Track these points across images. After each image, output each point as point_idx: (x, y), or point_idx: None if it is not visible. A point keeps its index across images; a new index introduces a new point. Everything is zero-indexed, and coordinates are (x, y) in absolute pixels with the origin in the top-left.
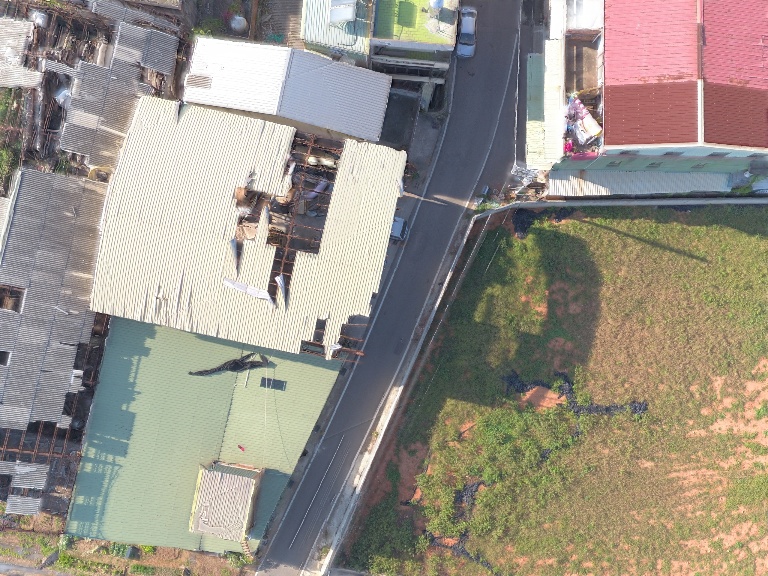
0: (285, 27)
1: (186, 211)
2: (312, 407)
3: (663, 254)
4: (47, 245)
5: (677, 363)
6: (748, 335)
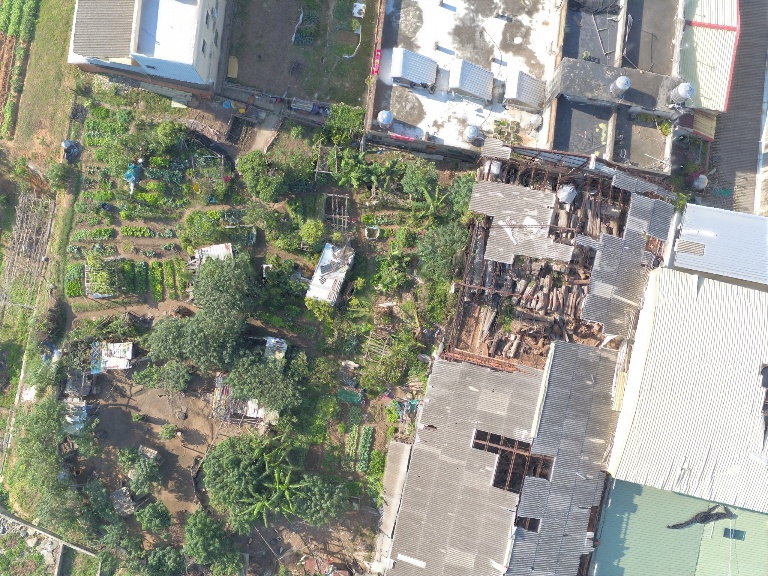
0: (730, 181)
1: (715, 386)
2: (766, 555)
3: None
4: (572, 414)
5: None
6: None
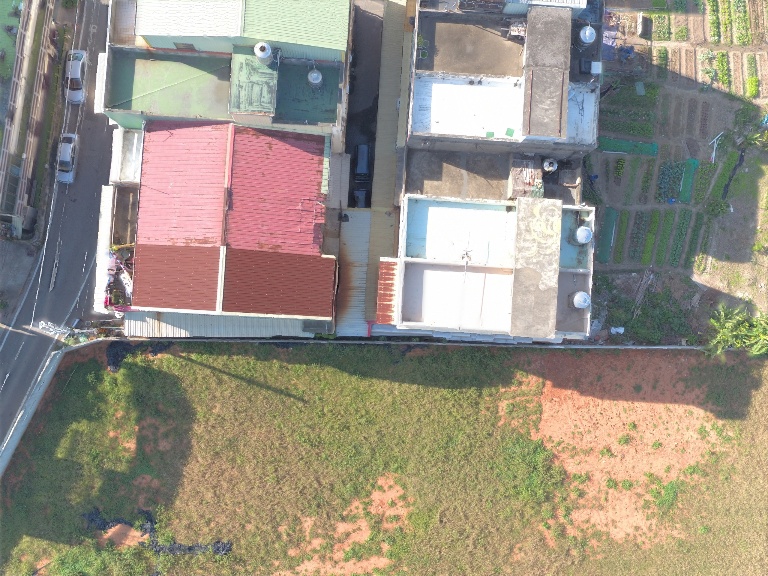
0: None
1: None
2: None
3: (259, 392)
4: None
5: (265, 504)
6: (340, 477)
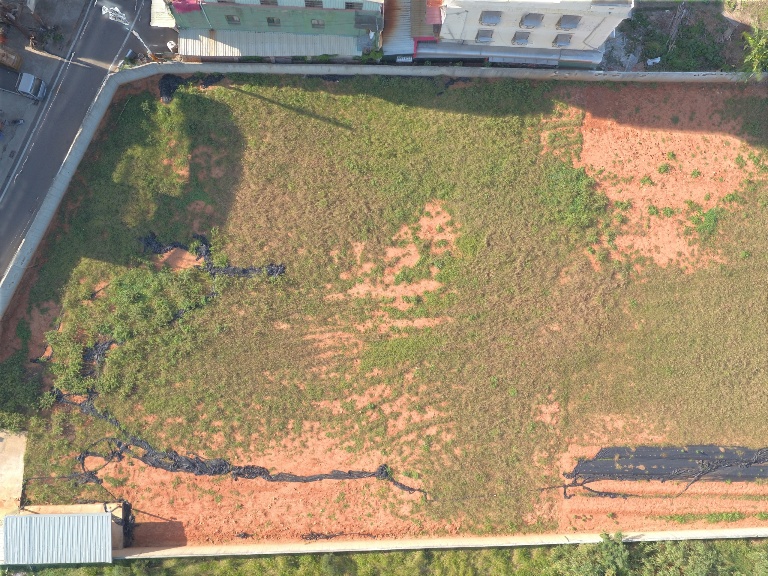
0: None
1: None
2: None
3: (307, 121)
4: None
5: (316, 228)
6: (389, 202)
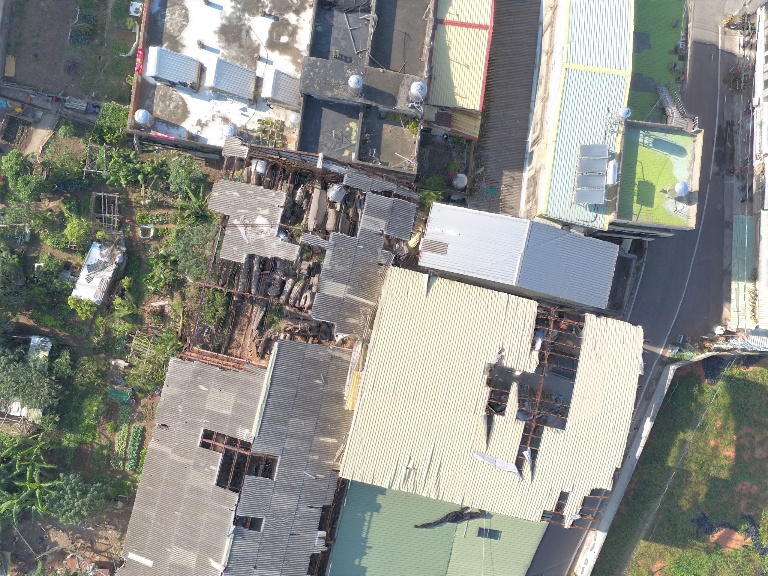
0: (498, 180)
1: (438, 386)
2: (524, 555)
3: None
4: (298, 413)
5: None
6: None
